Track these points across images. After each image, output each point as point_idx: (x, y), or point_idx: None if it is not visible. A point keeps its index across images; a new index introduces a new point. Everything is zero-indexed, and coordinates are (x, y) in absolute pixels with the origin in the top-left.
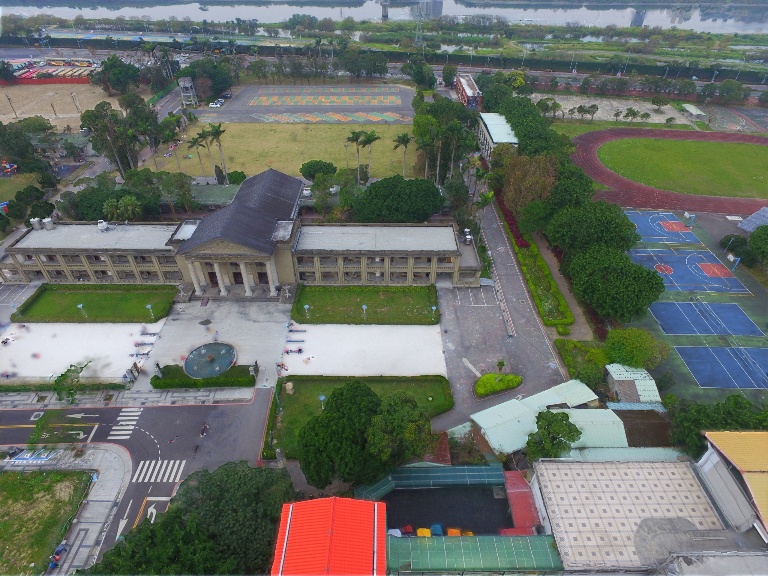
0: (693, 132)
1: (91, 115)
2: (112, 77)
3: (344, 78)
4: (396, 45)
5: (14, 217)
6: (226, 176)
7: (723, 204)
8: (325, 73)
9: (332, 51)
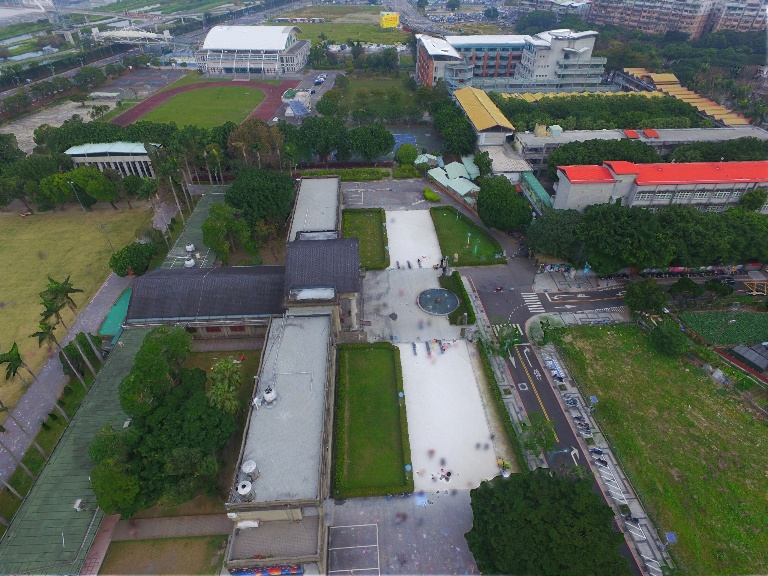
0: (140, 105)
1: None
2: None
3: None
4: None
5: None
6: (92, 345)
7: (257, 118)
8: None
9: None
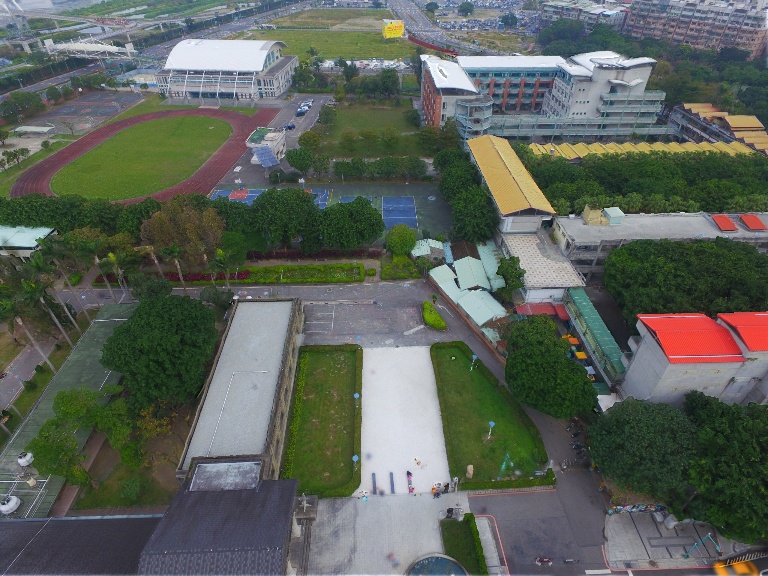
0: (75, 144)
1: None
2: None
3: None
4: None
5: None
6: None
7: (215, 167)
8: None
9: None
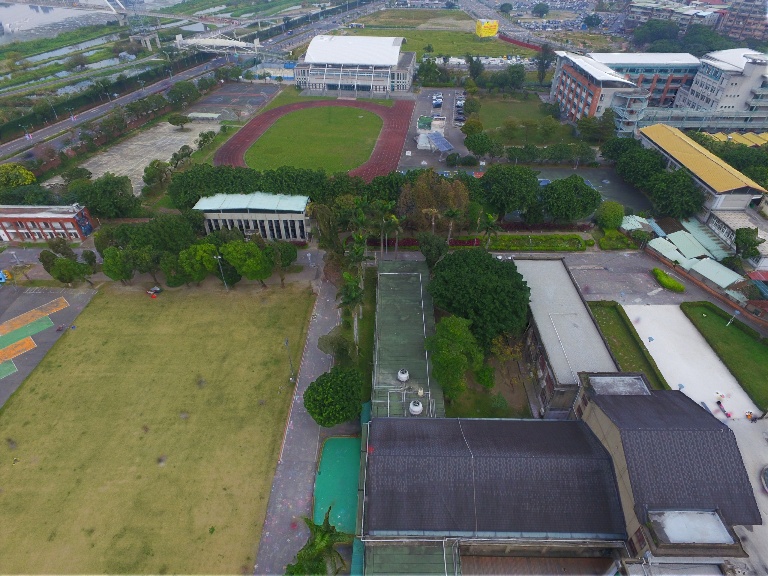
0: (245, 129)
1: None
2: None
3: None
4: None
5: None
6: None
7: (386, 152)
8: None
9: None
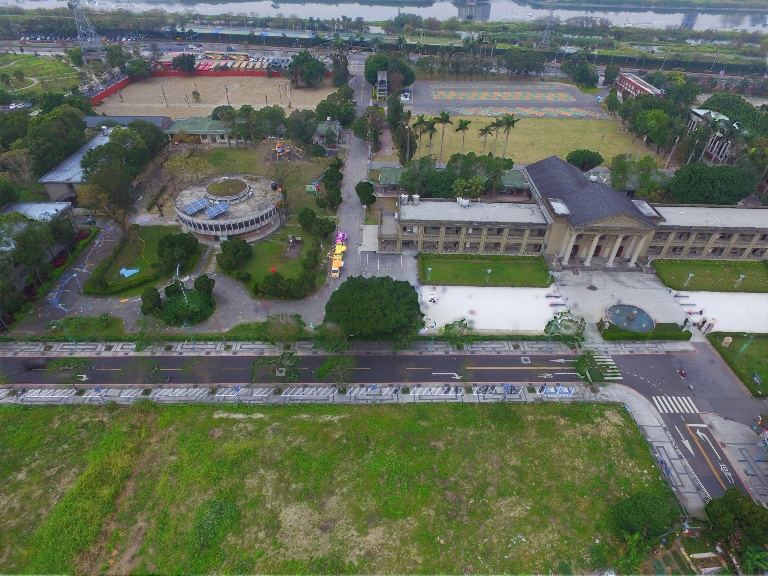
0: None
1: (328, 105)
2: (306, 70)
3: (501, 75)
4: (514, 45)
5: None
6: None
7: None
8: (488, 70)
9: (492, 49)
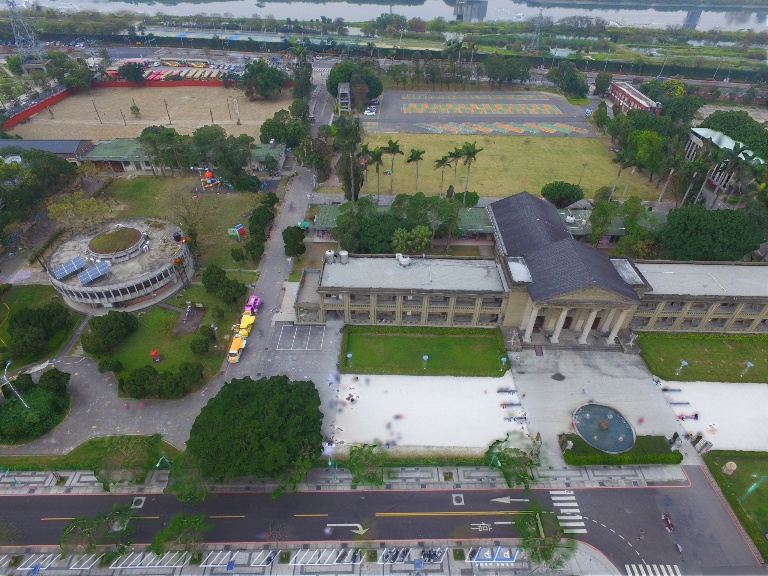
0: None
1: (274, 125)
2: (261, 81)
3: (482, 84)
4: (502, 48)
5: (261, 243)
6: (464, 198)
7: None
8: (467, 79)
9: (472, 55)
